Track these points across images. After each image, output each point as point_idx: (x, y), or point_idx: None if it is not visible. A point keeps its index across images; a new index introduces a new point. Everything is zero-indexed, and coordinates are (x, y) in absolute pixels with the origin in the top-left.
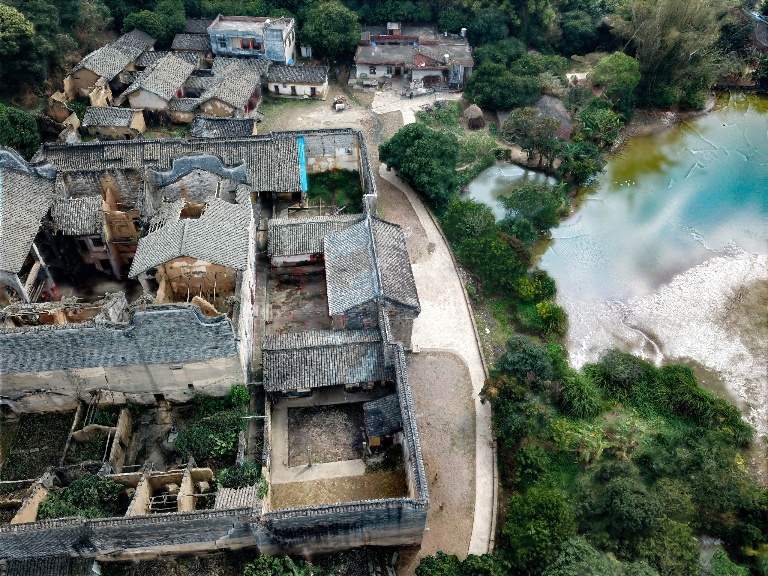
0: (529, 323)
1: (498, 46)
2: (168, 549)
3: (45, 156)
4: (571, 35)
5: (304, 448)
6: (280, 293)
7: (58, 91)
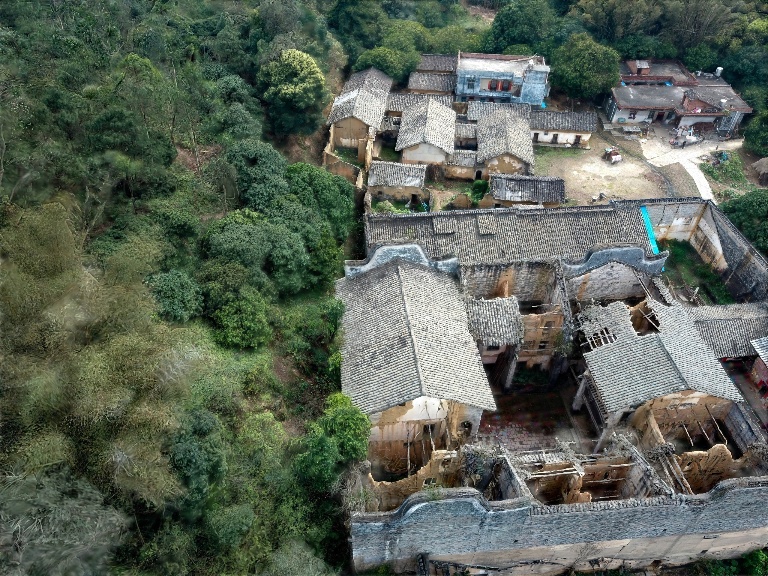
0: None
1: (767, 88)
2: None
3: None
4: None
5: None
6: None
7: None
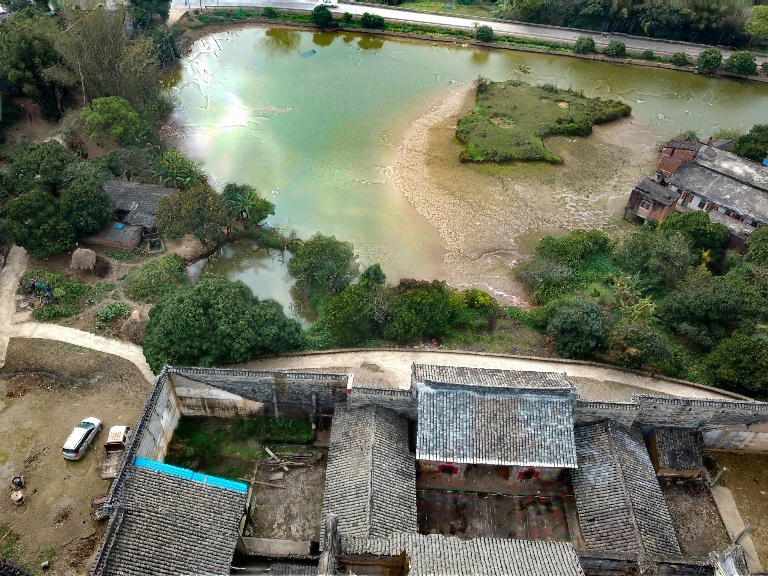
0: (485, 319)
1: None
2: None
3: None
4: None
5: (711, 548)
6: None
7: None
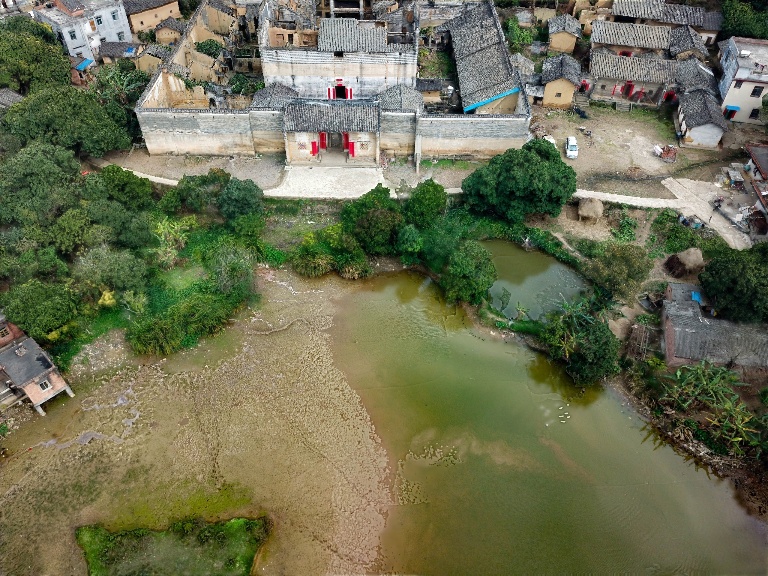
0: None
1: None
2: None
3: (483, 4)
4: None
5: None
6: None
7: (588, 1)
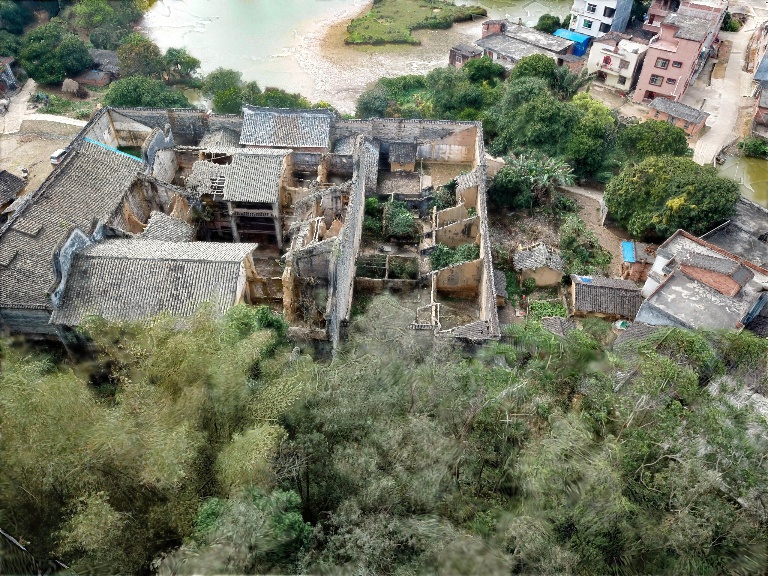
0: None
1: None
2: None
3: None
4: (8, 14)
5: None
6: None
7: None
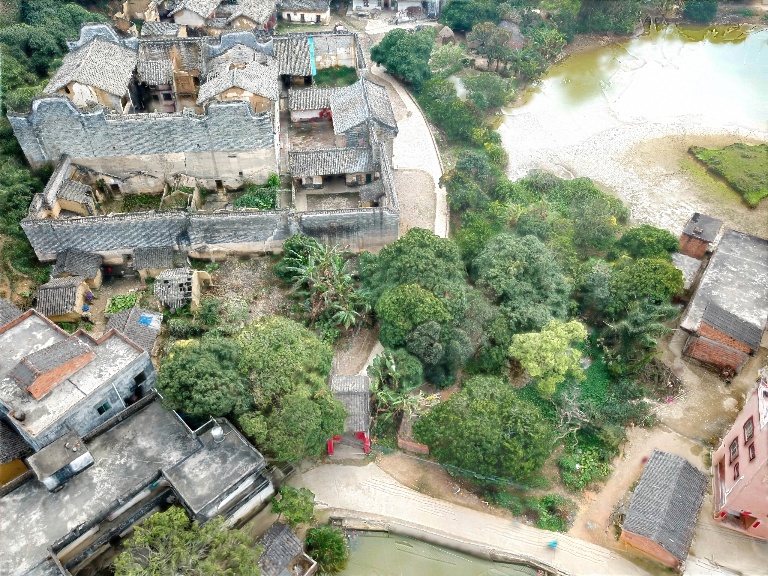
0: None
1: None
2: (234, 248)
3: None
4: None
5: None
6: (298, 138)
7: (119, 11)
